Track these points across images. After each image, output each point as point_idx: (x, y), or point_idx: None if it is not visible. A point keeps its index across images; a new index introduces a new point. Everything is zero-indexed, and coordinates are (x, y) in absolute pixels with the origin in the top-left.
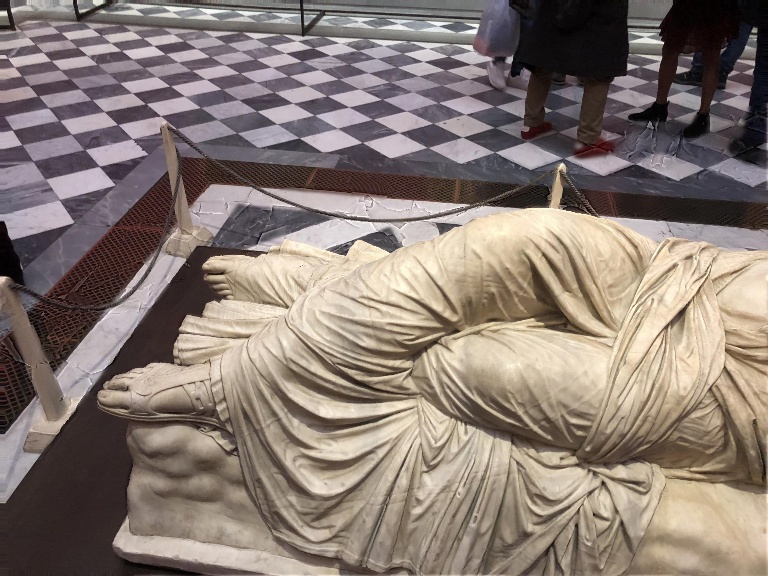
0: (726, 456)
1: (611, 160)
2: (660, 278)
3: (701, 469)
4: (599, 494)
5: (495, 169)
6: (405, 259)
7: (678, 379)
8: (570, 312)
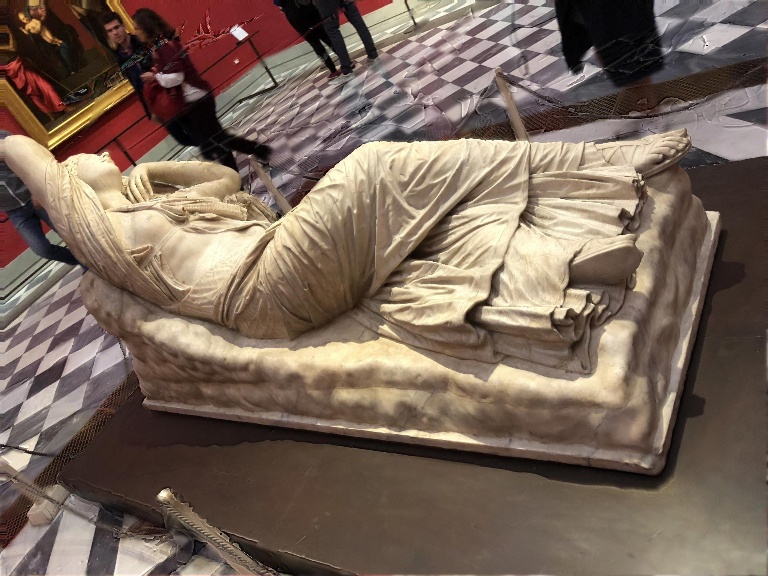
0: None
1: None
2: None
3: None
4: None
5: None
6: (434, 143)
7: None
8: None
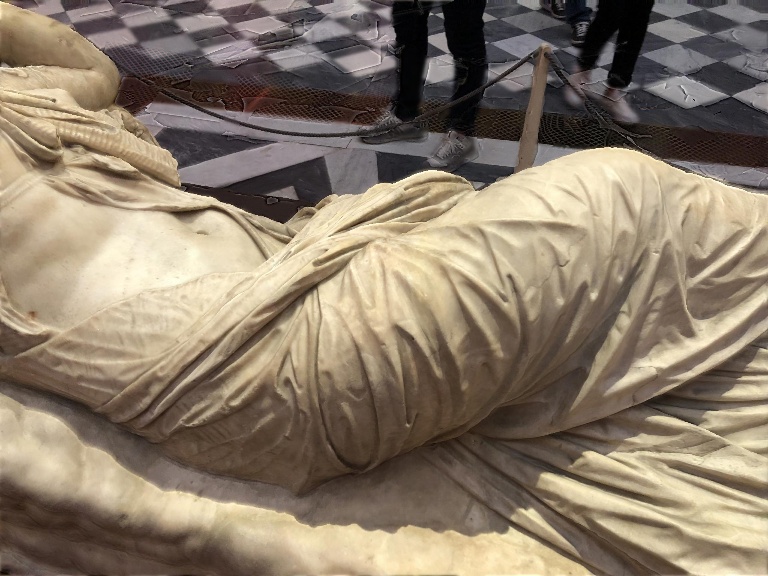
0: None
1: None
2: None
3: None
4: None
5: None
6: (741, 193)
7: None
8: None
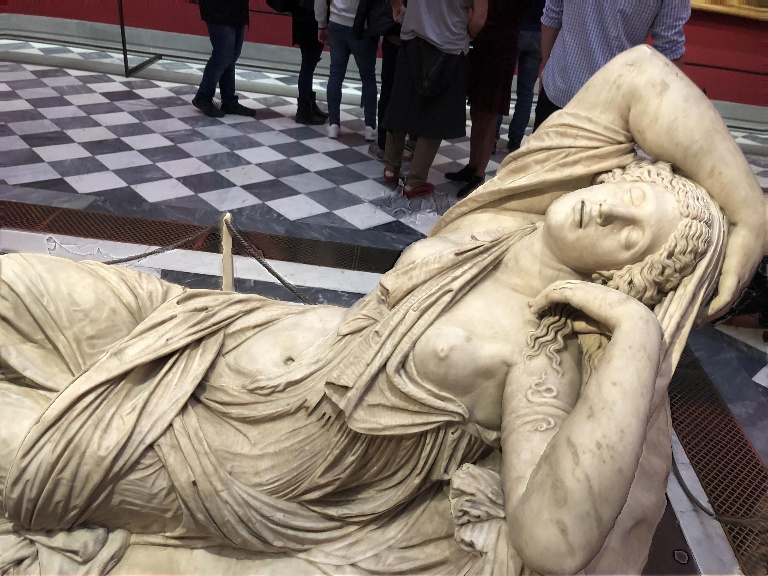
0: (184, 520)
1: (378, 215)
2: (149, 330)
3: (173, 534)
4: (30, 565)
5: (255, 218)
6: None
7: (103, 438)
8: (13, 364)
